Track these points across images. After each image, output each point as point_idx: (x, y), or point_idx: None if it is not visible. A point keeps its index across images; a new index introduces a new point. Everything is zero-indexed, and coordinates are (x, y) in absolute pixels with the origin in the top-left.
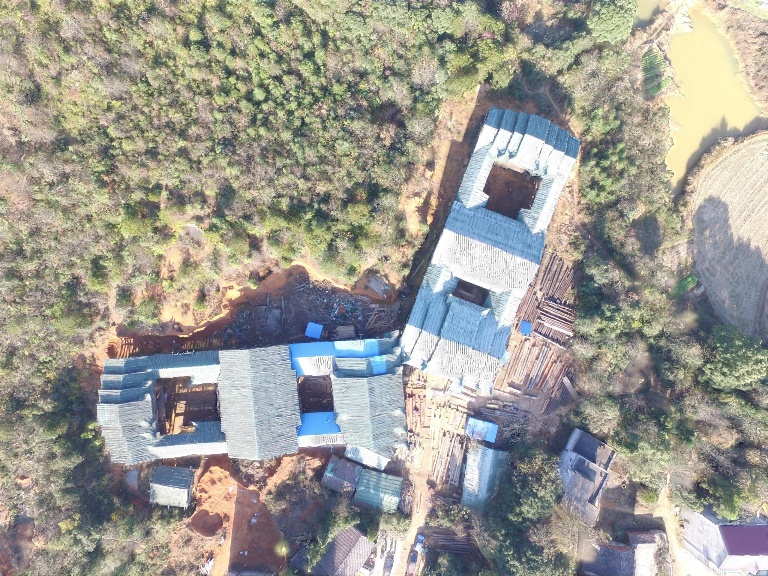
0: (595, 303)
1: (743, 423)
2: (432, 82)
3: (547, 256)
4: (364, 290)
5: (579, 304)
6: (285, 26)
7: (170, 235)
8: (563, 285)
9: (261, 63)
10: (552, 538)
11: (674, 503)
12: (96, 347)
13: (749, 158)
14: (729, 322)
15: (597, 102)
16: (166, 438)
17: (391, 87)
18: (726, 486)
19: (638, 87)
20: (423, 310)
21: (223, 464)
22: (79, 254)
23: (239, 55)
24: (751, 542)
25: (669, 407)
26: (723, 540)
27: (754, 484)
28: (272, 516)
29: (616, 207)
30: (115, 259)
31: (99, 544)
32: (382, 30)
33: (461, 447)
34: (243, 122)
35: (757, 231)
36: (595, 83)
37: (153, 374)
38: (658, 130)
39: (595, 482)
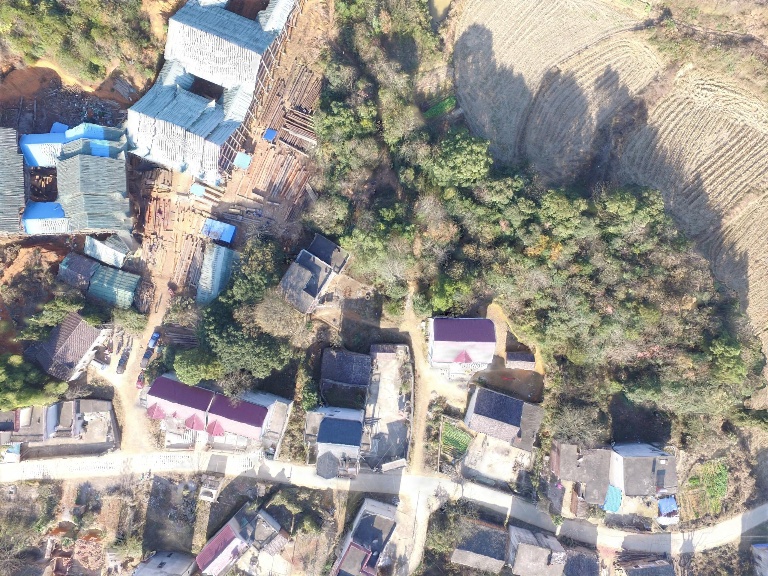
0: (329, 104)
1: (464, 219)
2: None
3: (297, 68)
4: (110, 92)
5: None
6: None
7: None
8: (311, 96)
9: None
10: (252, 314)
11: (420, 318)
12: None
13: None
14: None
15: None
16: None
17: None
18: (442, 278)
19: None
20: (151, 101)
21: None
22: None
23: None
24: (462, 332)
25: (394, 204)
26: (434, 329)
27: (467, 275)
28: (5, 305)
29: (365, 21)
30: None
31: None
32: None
33: (202, 250)
34: None
35: (521, 58)
36: None
37: None
38: None
39: (320, 277)
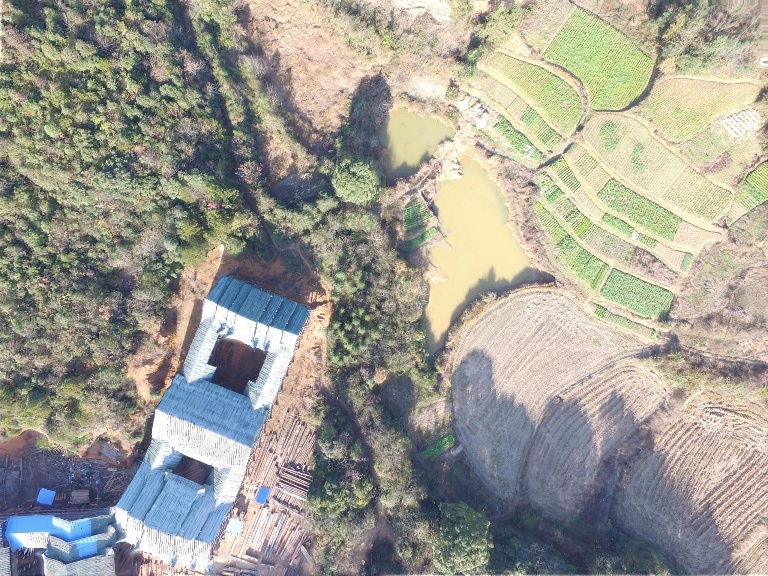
0: (323, 478)
1: None
2: (162, 249)
3: (289, 420)
4: (97, 456)
5: None
6: (5, 198)
7: None
8: (304, 450)
9: None
10: None
11: None
12: None
13: (515, 312)
14: (489, 482)
15: (341, 264)
16: None
17: (119, 255)
18: None
19: (401, 238)
20: (139, 488)
21: None
22: None
23: None
24: None
25: None
26: None
27: None
28: None
29: (359, 371)
30: None
31: None
32: (106, 200)
33: None
34: None
35: (521, 388)
36: (339, 244)
37: None
38: (402, 293)
39: None
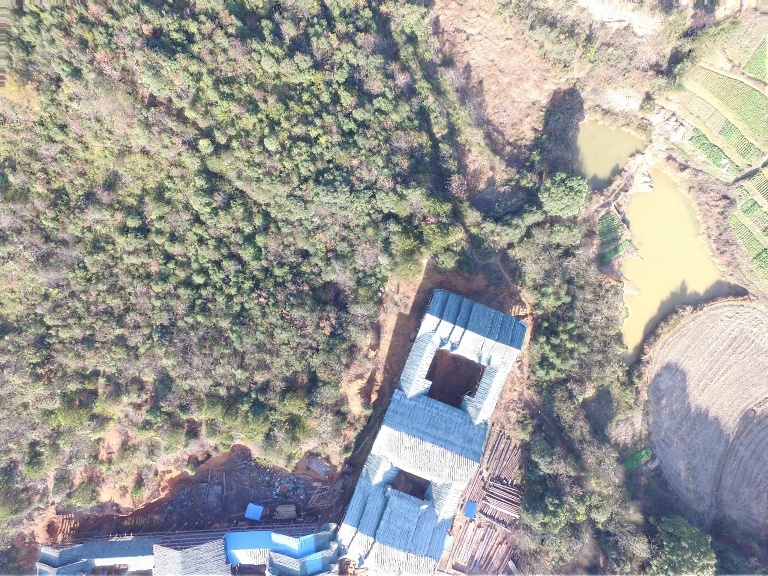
0: (540, 493)
1: None
2: (376, 263)
3: (494, 434)
4: (305, 471)
5: (525, 487)
6: (224, 212)
7: (108, 418)
8: (510, 464)
9: (199, 250)
10: None
11: None
12: (36, 525)
13: (709, 325)
14: (684, 495)
15: (548, 277)
16: None
17: (333, 269)
18: None
19: (594, 251)
20: (361, 503)
21: None
22: (16, 440)
23: (178, 239)
24: None
25: None
26: None
27: None
28: None
29: (566, 385)
30: (51, 449)
31: None
32: (323, 214)
33: None
34: (180, 310)
35: (716, 401)
36: (546, 258)
37: (88, 563)
38: (610, 307)
39: None
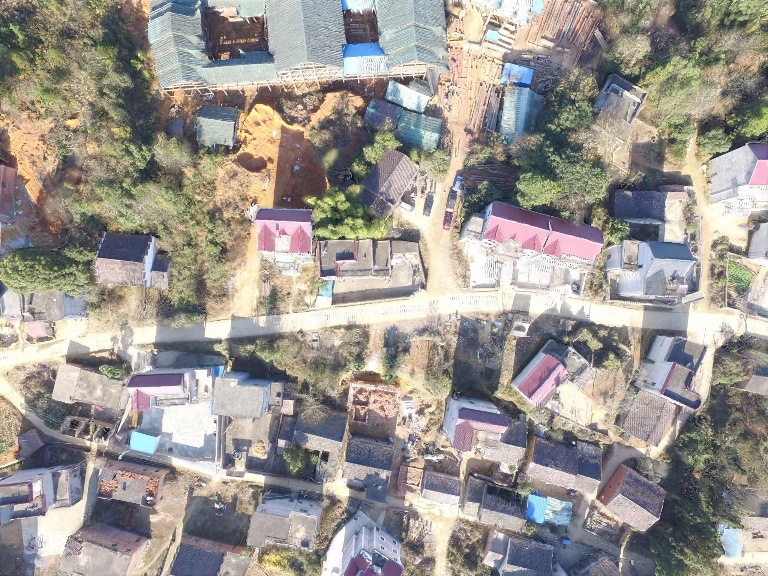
0: None
1: None
2: None
3: None
4: None
5: None
6: None
7: None
8: None
9: None
10: (591, 135)
11: (701, 161)
12: None
13: None
14: None
15: None
16: (214, 62)
17: None
18: (754, 105)
19: None
20: None
21: (268, 104)
22: None
23: None
24: None
25: None
26: (753, 151)
27: None
28: (316, 148)
29: None
30: None
31: (148, 169)
32: None
33: (497, 96)
34: None
35: None
36: None
37: (202, 0)
38: None
39: (628, 111)
